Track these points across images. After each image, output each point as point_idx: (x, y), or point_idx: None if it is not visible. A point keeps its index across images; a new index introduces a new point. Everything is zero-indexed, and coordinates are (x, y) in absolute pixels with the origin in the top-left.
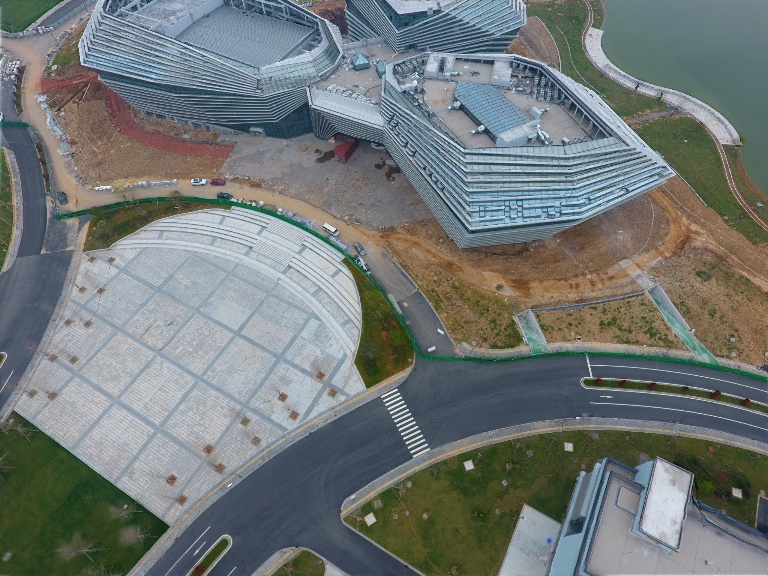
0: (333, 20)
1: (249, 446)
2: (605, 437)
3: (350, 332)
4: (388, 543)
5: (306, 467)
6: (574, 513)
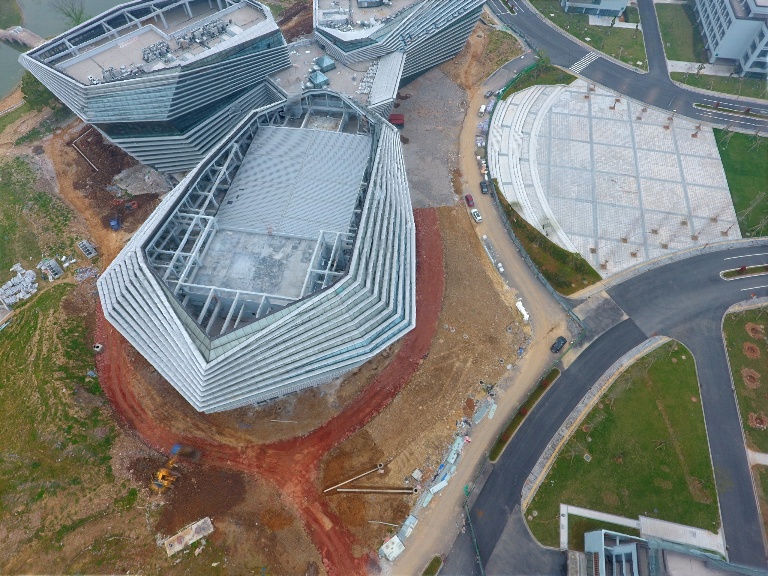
0: (137, 203)
1: (649, 113)
2: (539, 7)
3: (550, 91)
4: (643, 56)
5: (638, 90)
6: (589, 1)
